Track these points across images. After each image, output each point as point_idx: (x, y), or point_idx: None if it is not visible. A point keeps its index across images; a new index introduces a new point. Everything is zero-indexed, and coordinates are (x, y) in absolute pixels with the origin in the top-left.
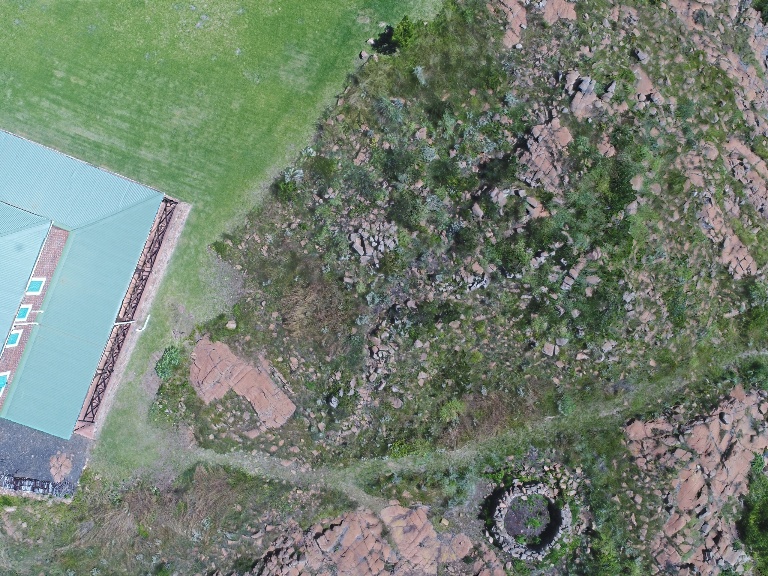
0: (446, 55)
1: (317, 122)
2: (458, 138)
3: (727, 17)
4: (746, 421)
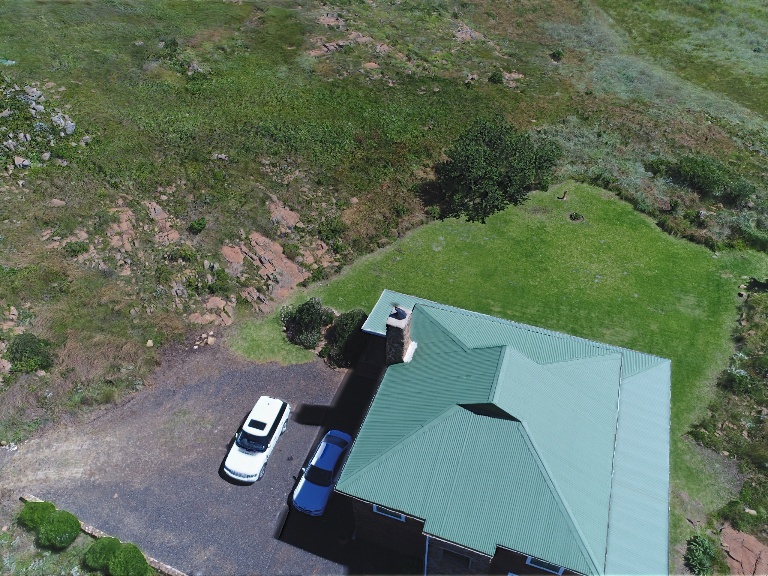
0: None
1: (732, 337)
2: None
3: None
4: None
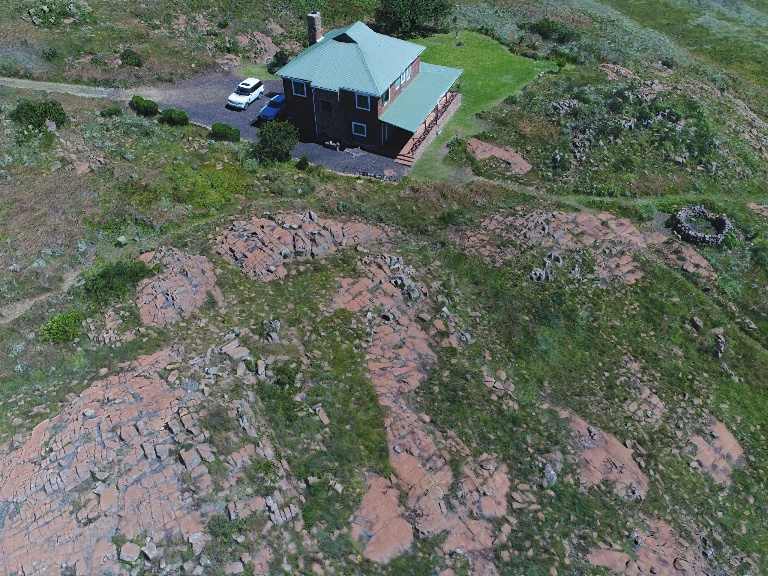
0: (582, 75)
1: (522, 89)
2: None
3: None
4: None
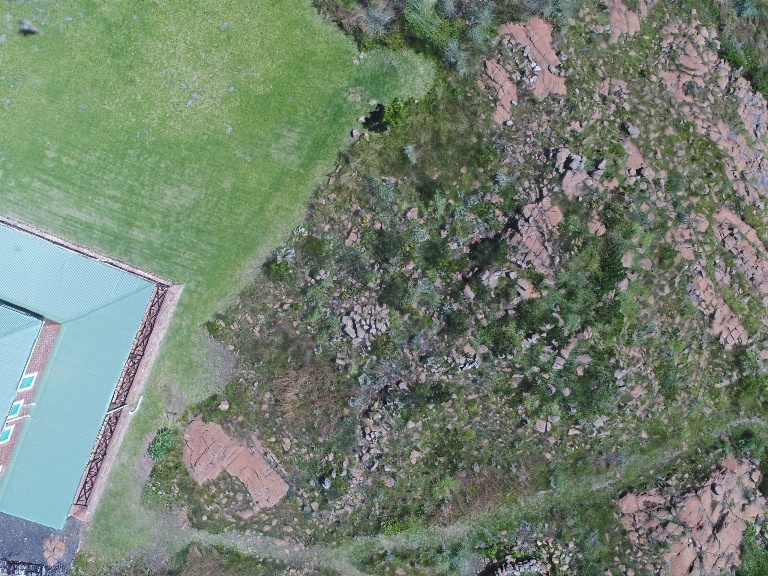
0: (437, 134)
1: (309, 201)
2: (449, 218)
3: (717, 87)
4: (738, 490)
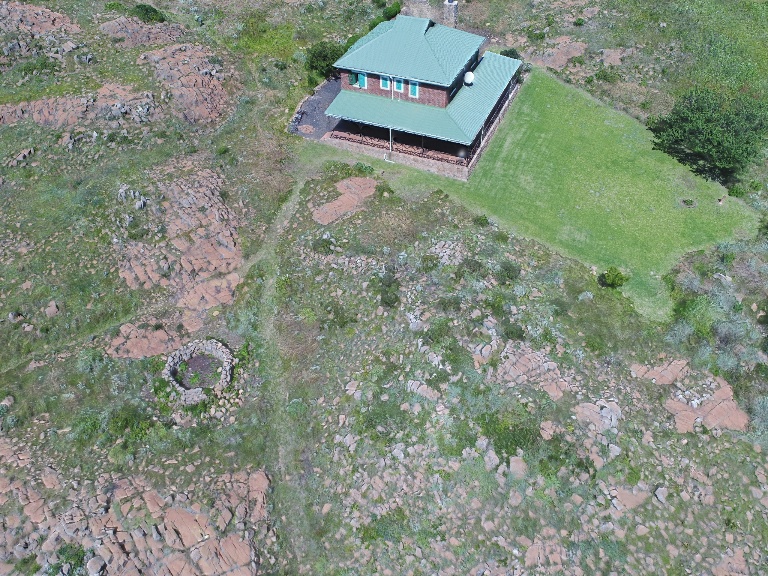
0: None
1: None
2: None
3: None
4: None
